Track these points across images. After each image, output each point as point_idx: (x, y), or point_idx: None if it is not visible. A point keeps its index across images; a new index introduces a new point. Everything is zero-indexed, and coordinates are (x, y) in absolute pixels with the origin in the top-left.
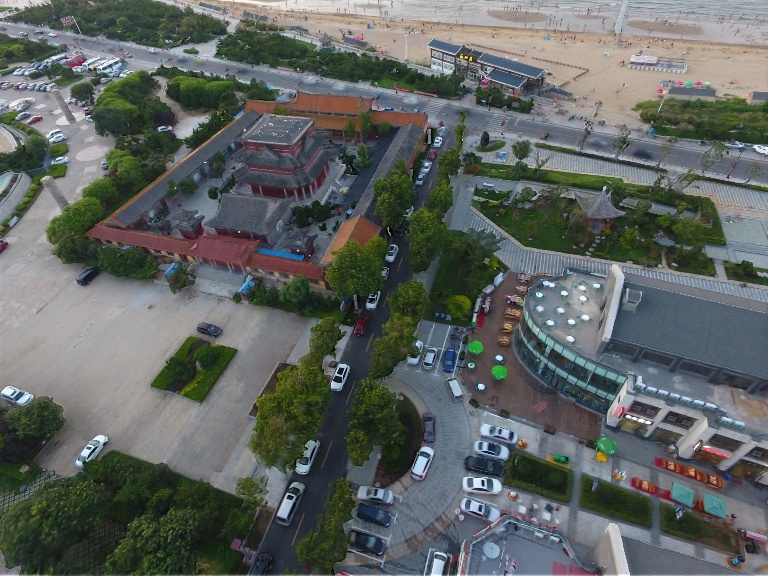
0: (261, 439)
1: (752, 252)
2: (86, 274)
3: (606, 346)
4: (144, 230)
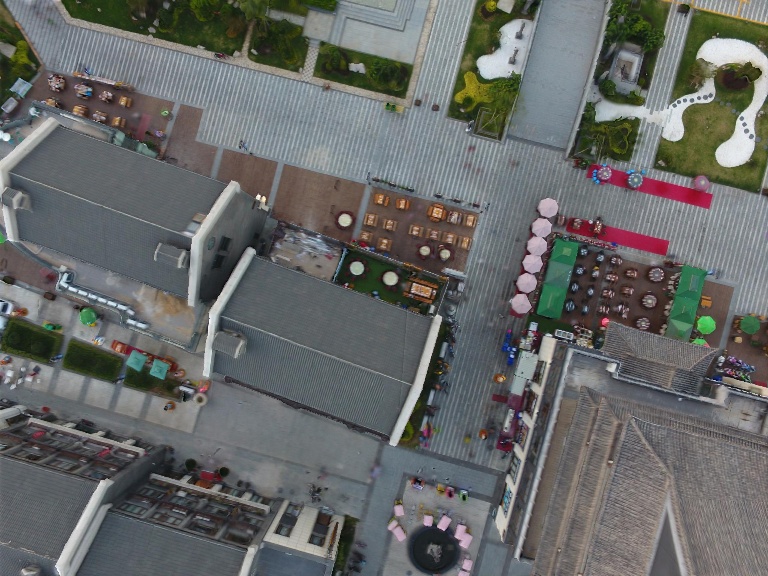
0: None
1: (368, 21)
2: None
3: None
4: None
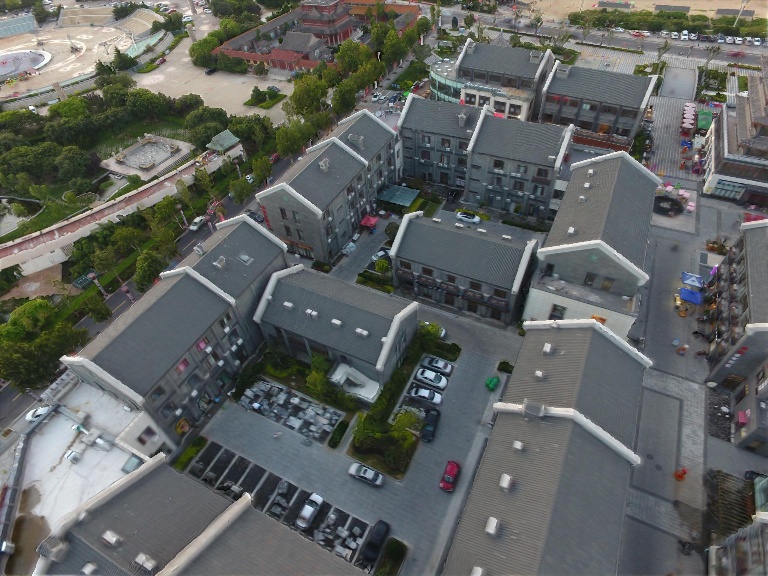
0: (294, 94)
1: None
2: (210, 69)
3: (459, 72)
4: None
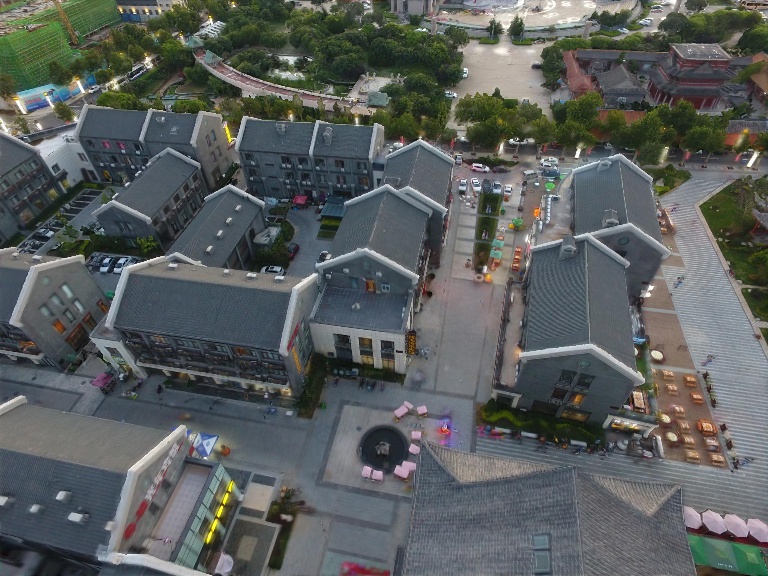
0: None
1: None
2: (538, 64)
3: (572, 182)
4: (584, 69)
